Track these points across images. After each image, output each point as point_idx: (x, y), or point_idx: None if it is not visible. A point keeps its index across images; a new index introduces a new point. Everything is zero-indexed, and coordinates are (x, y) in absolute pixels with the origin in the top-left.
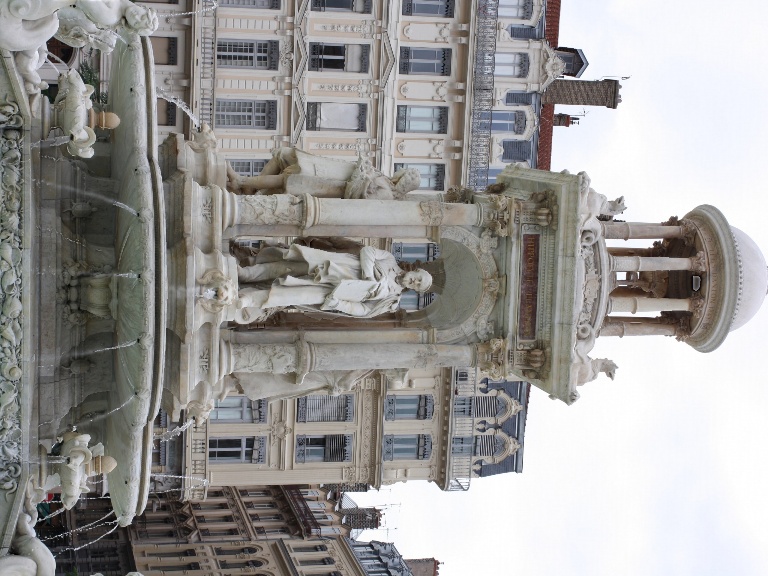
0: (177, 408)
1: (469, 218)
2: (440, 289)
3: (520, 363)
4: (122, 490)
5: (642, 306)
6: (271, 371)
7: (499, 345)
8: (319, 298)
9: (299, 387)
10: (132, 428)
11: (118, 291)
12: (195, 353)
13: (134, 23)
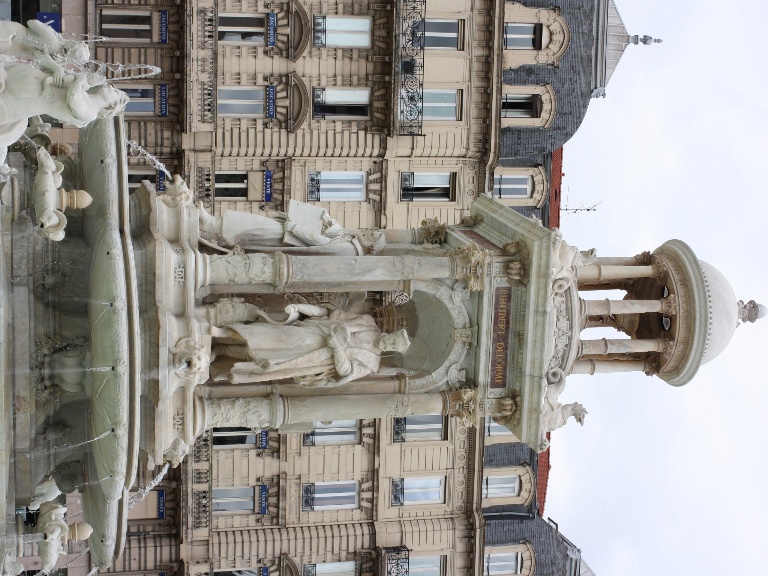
0: (162, 307)
1: (403, 231)
2: (412, 307)
3: (497, 255)
4: (106, 275)
5: (605, 266)
6: (249, 263)
7: (469, 247)
8: (277, 224)
9: (294, 335)
10: (104, 183)
11: (79, 156)
12: (167, 243)
13: (71, 45)
